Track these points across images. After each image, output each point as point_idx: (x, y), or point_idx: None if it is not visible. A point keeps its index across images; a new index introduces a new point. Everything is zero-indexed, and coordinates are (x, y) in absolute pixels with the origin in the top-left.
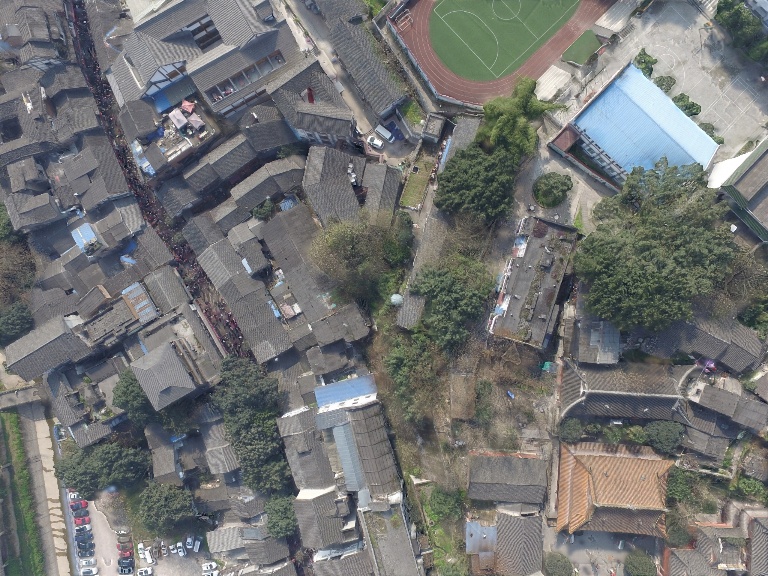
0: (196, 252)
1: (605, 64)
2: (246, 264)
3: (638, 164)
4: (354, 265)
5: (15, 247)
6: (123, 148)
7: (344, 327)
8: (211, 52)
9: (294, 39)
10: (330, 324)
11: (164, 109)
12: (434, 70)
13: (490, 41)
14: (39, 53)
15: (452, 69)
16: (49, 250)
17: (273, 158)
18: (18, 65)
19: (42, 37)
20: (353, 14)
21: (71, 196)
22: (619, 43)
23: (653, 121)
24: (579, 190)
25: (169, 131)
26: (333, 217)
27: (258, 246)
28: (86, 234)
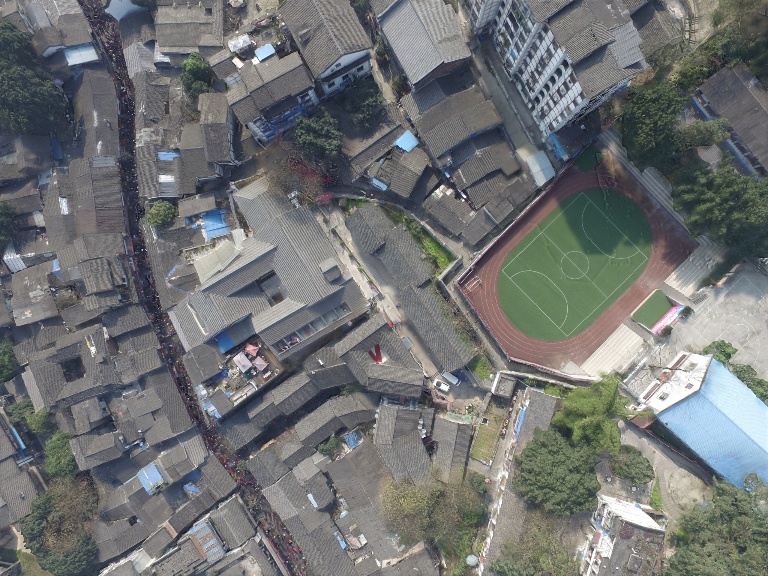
0: (260, 483)
1: (679, 334)
2: (312, 499)
3: (722, 460)
4: (431, 535)
5: (78, 478)
6: (183, 375)
7: (415, 571)
8: (277, 307)
9: (360, 292)
10: (401, 570)
11: (227, 350)
12: (504, 330)
13: (559, 300)
14: (103, 303)
15: (522, 329)
16: (112, 478)
17: (336, 390)
18: (76, 291)
19: (106, 288)
20: (422, 280)
21: (134, 430)
22: (692, 313)
23: (739, 429)
24: (656, 460)
25: (233, 371)
26: (406, 478)
27: (323, 479)
28: (152, 476)
